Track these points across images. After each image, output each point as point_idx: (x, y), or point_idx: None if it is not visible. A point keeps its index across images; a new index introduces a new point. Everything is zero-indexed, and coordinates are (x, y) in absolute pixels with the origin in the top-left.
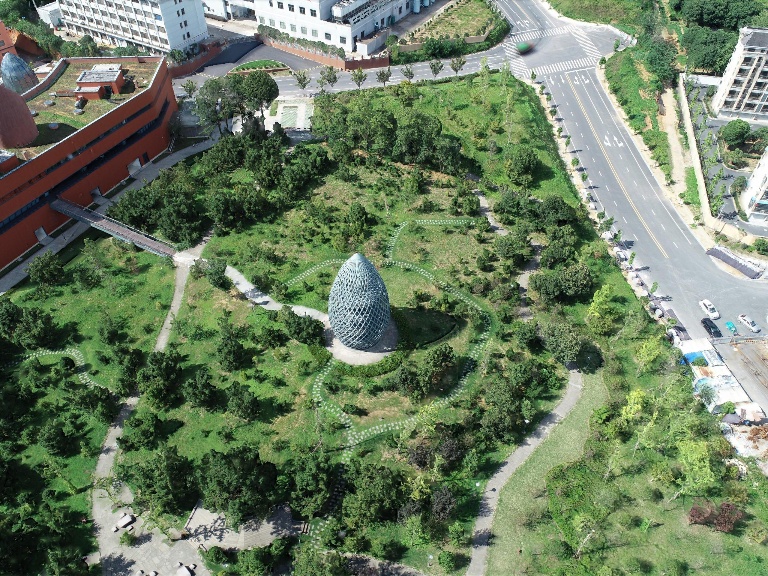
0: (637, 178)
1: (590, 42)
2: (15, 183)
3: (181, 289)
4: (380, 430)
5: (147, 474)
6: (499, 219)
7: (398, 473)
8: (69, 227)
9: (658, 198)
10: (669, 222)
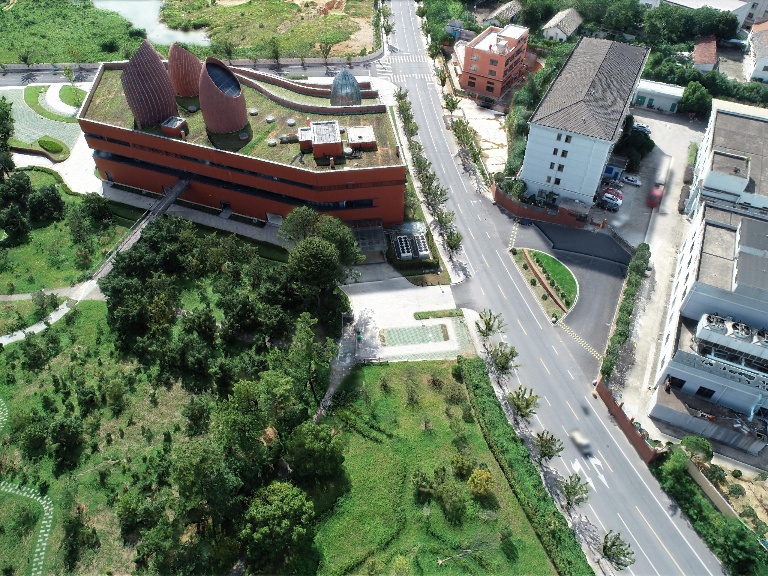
0: None
1: None
2: (154, 144)
3: None
4: None
5: None
6: None
7: None
8: (185, 206)
9: None
10: None
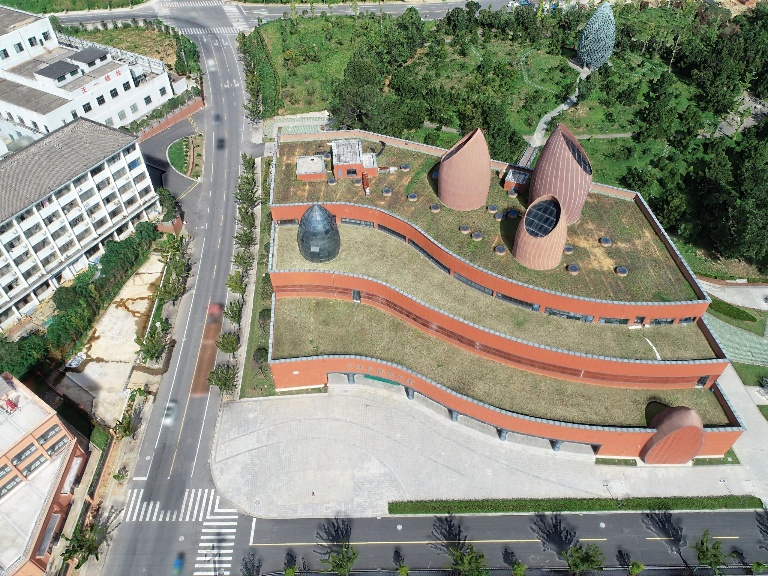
0: (398, 8)
1: (193, 2)
2: None
3: None
4: None
5: None
6: (467, 34)
7: None
8: None
9: (418, 5)
10: (442, 5)
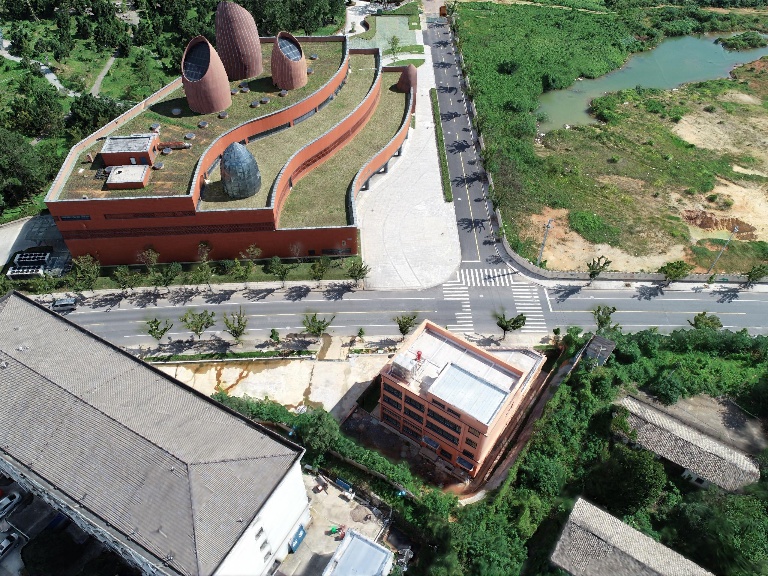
0: None
1: None
2: None
3: (96, 84)
4: (6, 27)
5: (108, 4)
6: None
7: (5, 2)
8: None
9: None
10: None
